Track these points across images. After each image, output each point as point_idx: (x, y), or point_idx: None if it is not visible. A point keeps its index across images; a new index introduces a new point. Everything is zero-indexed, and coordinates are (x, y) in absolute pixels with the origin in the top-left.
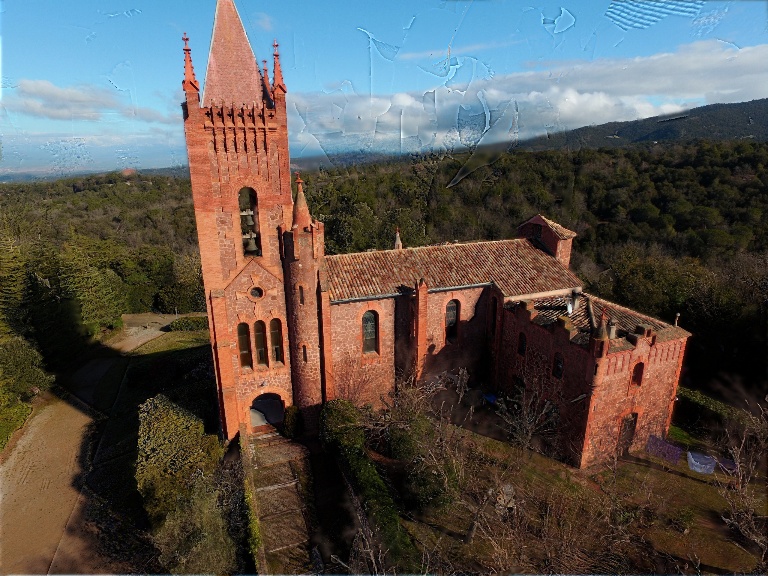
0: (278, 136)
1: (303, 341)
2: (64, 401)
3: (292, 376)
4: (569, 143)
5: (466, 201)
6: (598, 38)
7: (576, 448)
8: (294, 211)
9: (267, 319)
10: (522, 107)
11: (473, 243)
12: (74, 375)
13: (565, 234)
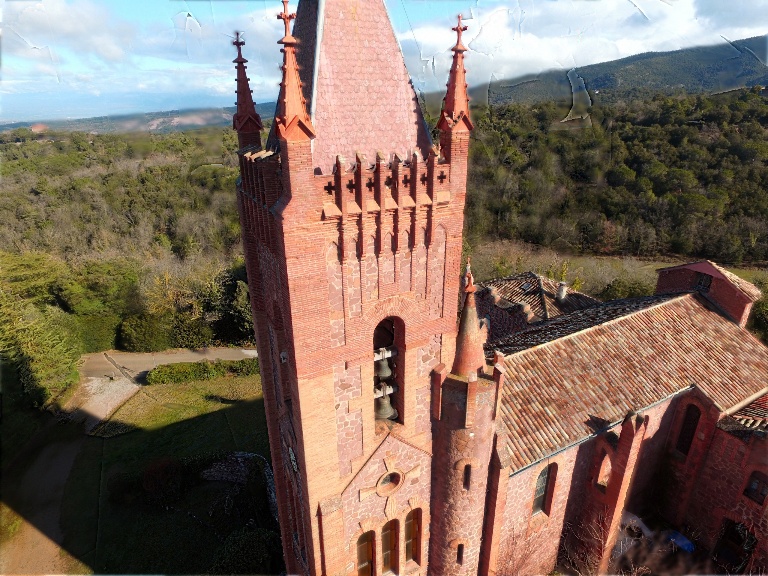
0: (449, 215)
1: (460, 538)
2: (16, 539)
3: (428, 575)
4: (591, 114)
5: (485, 187)
6: None
7: None
8: (459, 340)
9: (402, 514)
10: (564, 76)
11: (636, 313)
12: (24, 481)
13: (753, 292)
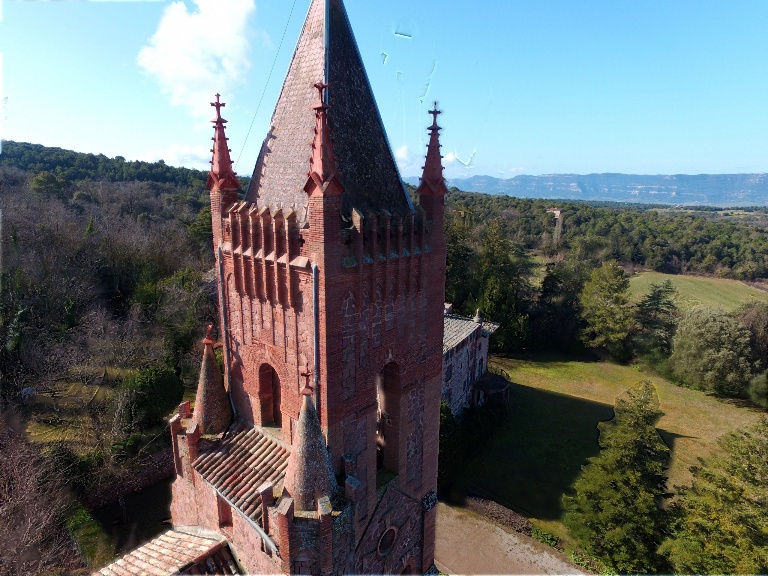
0: None
1: None
2: None
3: None
4: None
5: None
6: None
7: None
8: None
9: None
10: None
11: None
12: None
13: None
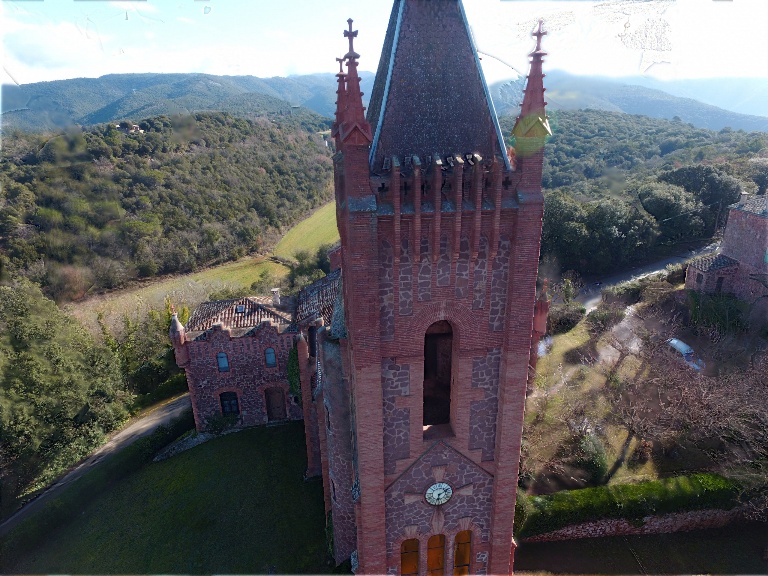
0: None
1: None
2: None
3: None
4: None
5: None
6: (99, 27)
7: (530, 381)
8: None
9: None
10: (54, 106)
11: None
12: None
13: None
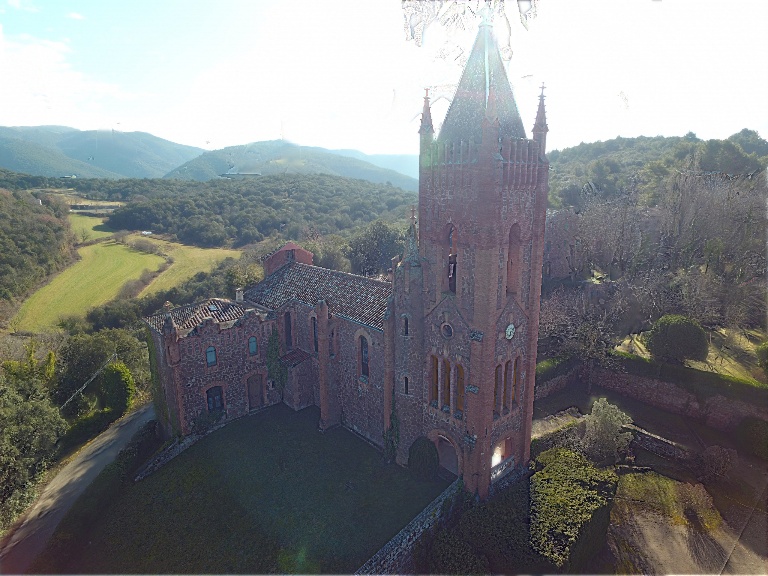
0: None
1: None
2: None
3: None
4: None
5: None
6: None
7: None
8: None
9: None
10: None
11: None
12: None
13: None
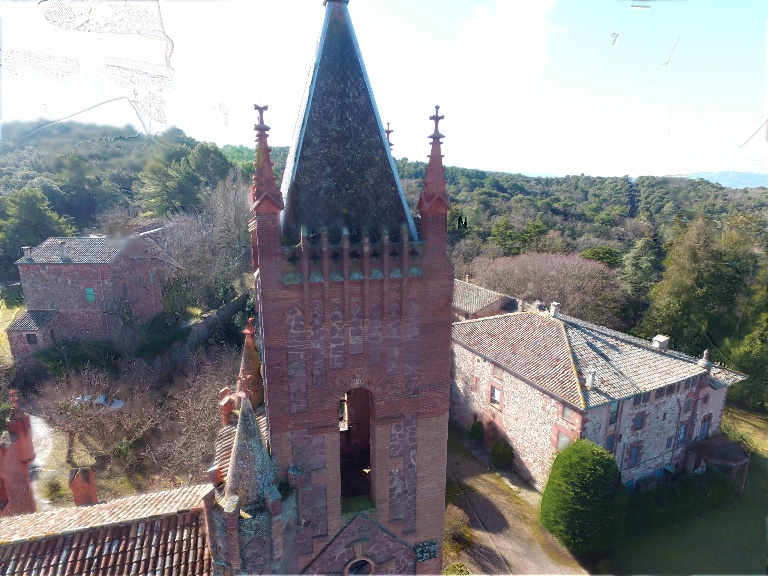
0: None
1: None
2: None
3: None
4: None
5: None
6: None
7: None
8: None
9: None
10: None
11: None
12: None
13: None
